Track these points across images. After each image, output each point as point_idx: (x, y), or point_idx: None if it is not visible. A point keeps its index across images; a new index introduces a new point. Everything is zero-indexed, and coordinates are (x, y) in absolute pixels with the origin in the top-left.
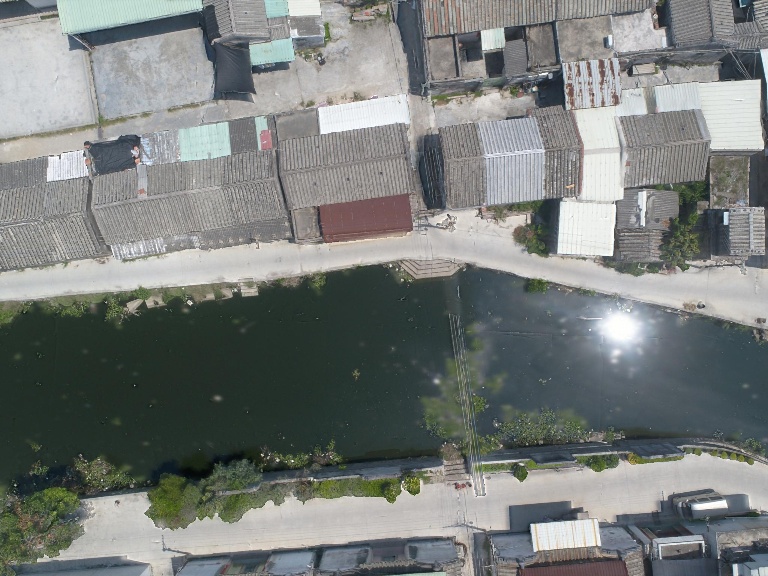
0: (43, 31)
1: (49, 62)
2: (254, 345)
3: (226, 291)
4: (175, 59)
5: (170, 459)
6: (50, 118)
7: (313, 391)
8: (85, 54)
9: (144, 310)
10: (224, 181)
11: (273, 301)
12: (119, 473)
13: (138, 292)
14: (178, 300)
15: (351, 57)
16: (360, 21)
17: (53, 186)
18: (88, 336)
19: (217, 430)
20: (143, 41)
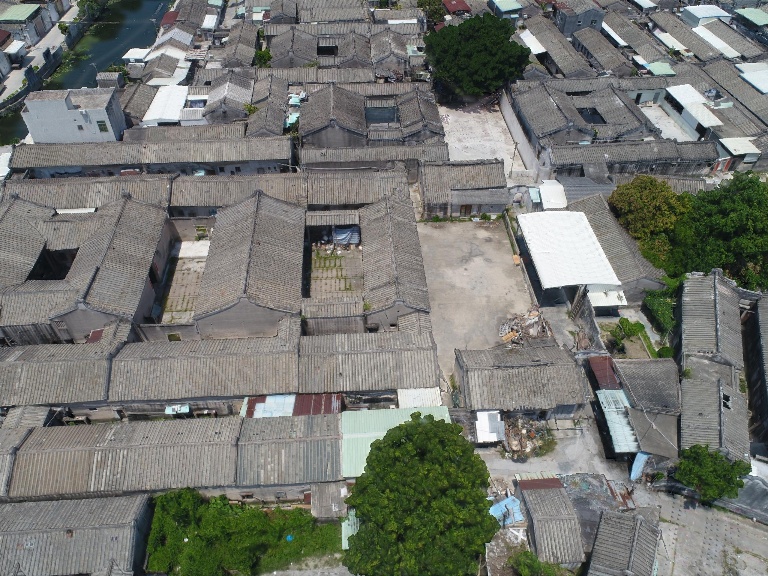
0: None
1: None
2: None
3: None
4: None
5: (111, 10)
6: None
7: (116, 31)
8: None
9: None
10: None
11: None
12: (113, 3)
13: None
14: None
15: None
16: None
17: None
18: None
19: None
20: None
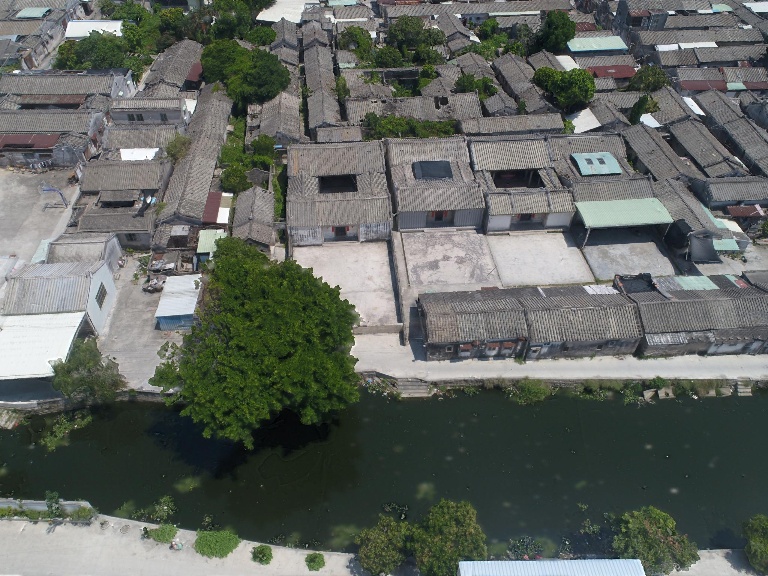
0: (548, 238)
1: (555, 251)
2: (766, 432)
3: (725, 389)
4: (641, 255)
5: (723, 528)
6: (561, 277)
7: None
8: (578, 250)
9: (656, 400)
10: (730, 296)
11: (760, 406)
12: None
13: (656, 380)
14: (683, 395)
15: (763, 260)
16: (760, 245)
17: (598, 295)
18: (607, 419)
19: (759, 504)
20: (617, 246)
